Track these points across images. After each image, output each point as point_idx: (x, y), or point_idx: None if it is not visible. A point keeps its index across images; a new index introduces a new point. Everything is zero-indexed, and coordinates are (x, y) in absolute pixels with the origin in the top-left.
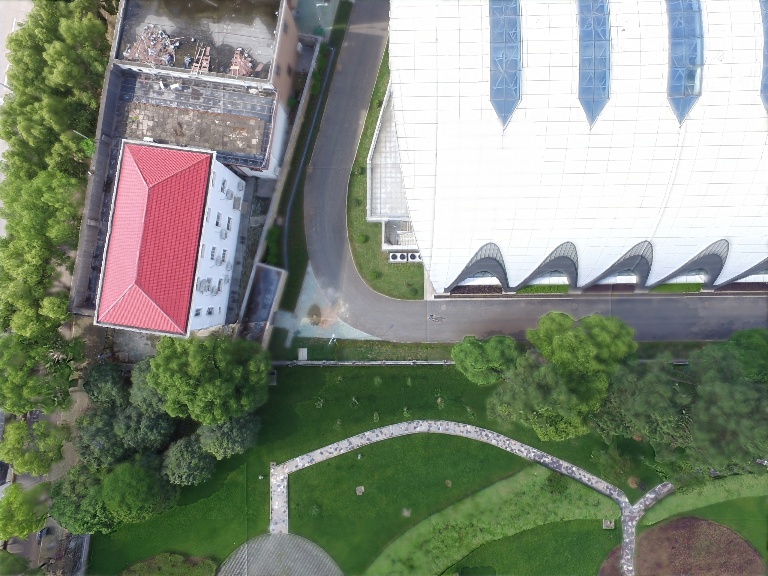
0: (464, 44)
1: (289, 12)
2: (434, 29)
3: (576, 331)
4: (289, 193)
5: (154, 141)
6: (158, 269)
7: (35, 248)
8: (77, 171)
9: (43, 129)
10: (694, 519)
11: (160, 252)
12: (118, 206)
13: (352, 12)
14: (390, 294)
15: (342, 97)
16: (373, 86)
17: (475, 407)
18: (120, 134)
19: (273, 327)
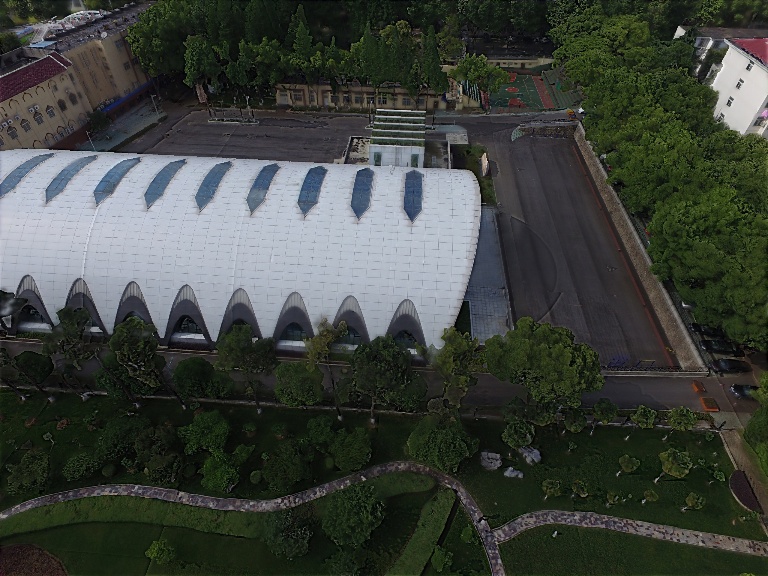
0: (3, 168)
1: None
2: None
3: None
4: None
5: None
6: None
7: None
8: None
9: None
10: (27, 545)
11: None
12: None
13: None
14: None
15: None
16: None
17: None
18: None
19: None
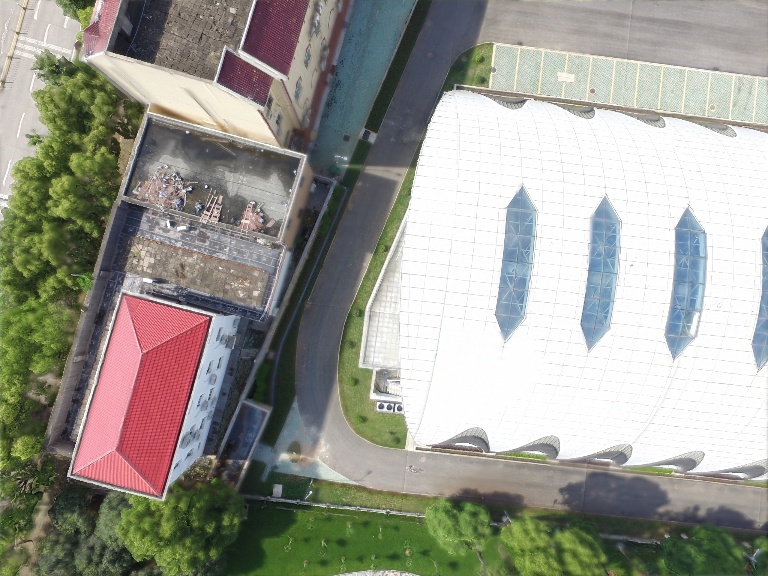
0: (477, 258)
1: (307, 164)
2: (449, 239)
3: (550, 554)
4: (284, 329)
5: (153, 281)
6: (141, 434)
7: (15, 385)
8: (69, 298)
9: (39, 265)
10: None
11: (146, 417)
12: (108, 359)
13: (370, 152)
14: (372, 440)
15: (349, 236)
16: (382, 229)
17: (442, 562)
18: (119, 268)
19: (251, 460)
